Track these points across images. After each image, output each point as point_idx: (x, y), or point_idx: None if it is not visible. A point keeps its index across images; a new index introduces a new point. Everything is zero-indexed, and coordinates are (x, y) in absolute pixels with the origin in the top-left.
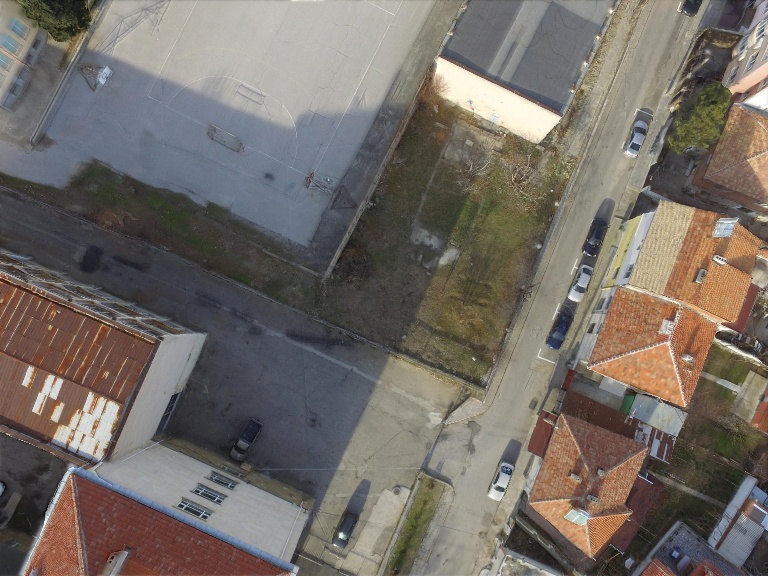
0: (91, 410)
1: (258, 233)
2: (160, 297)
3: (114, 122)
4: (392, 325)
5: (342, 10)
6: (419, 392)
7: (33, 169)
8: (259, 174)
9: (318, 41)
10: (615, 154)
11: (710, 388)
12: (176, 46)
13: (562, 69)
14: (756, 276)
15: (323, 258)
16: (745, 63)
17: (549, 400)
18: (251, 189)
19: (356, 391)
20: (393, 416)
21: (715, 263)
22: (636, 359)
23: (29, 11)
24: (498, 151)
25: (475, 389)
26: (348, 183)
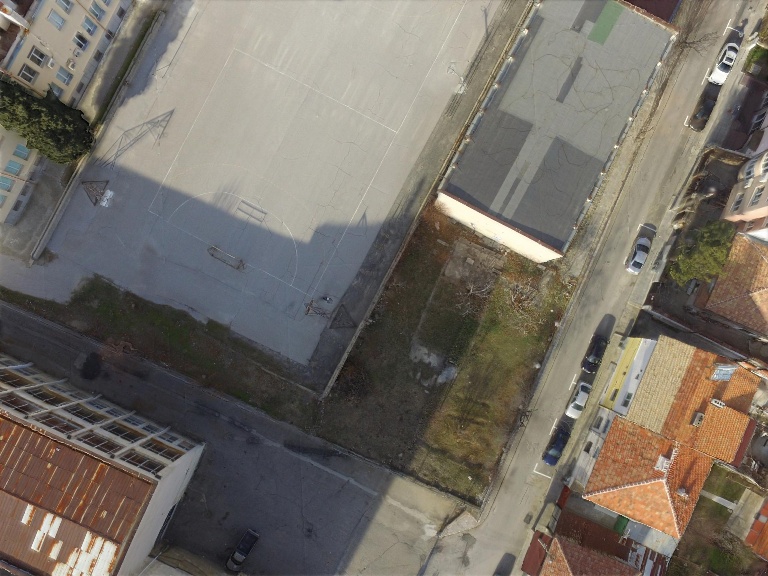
0: (89, 549)
1: (257, 351)
2: (159, 405)
3: (115, 237)
4: (389, 442)
5: (344, 126)
6: (415, 504)
7: (34, 283)
8: (259, 292)
9: (320, 158)
10: (617, 269)
11: (705, 505)
12: (177, 161)
13: (564, 206)
14: (755, 395)
15: (321, 377)
16: (750, 194)
17: (544, 515)
18: (250, 307)
19: (352, 502)
20: (389, 527)
21: (713, 405)
22: (631, 492)
23: (30, 143)
24: (499, 269)
25: None
26: (347, 302)
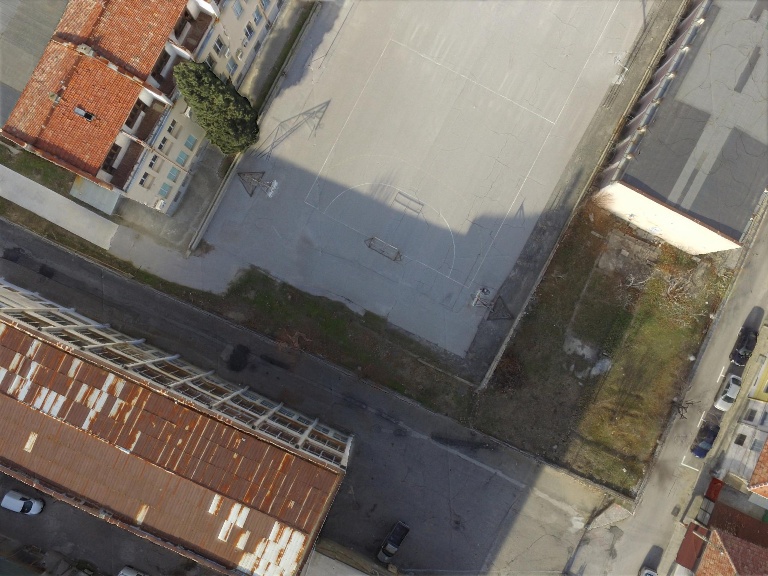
0: (277, 539)
1: (414, 343)
2: (306, 397)
3: (271, 228)
4: (543, 434)
5: (501, 118)
6: (562, 497)
7: (191, 274)
8: (416, 283)
9: (477, 149)
10: (765, 262)
11: None
12: (333, 152)
13: (742, 197)
14: None
15: (478, 369)
16: None
17: (692, 507)
18: (408, 298)
19: (500, 494)
20: (536, 520)
21: None
22: None
23: (210, 133)
24: (653, 261)
25: (625, 500)
26: (505, 294)
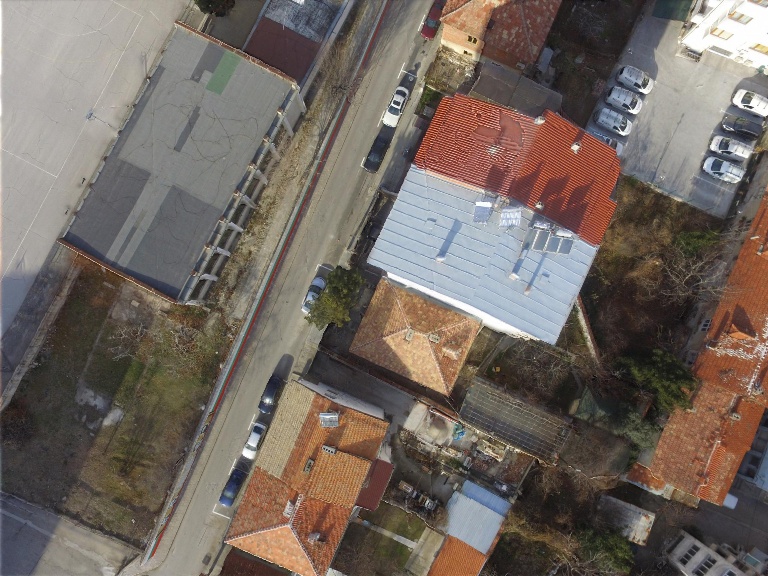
0: None
1: None
2: None
3: None
4: (53, 486)
5: (4, 171)
6: (92, 546)
7: None
8: None
9: None
10: (295, 309)
11: (386, 544)
12: None
13: (181, 254)
14: (433, 433)
15: None
16: None
17: (222, 556)
18: None
19: (29, 545)
20: (66, 570)
21: None
22: (266, 537)
23: None
24: (165, 312)
25: (135, 551)
26: (5, 346)
